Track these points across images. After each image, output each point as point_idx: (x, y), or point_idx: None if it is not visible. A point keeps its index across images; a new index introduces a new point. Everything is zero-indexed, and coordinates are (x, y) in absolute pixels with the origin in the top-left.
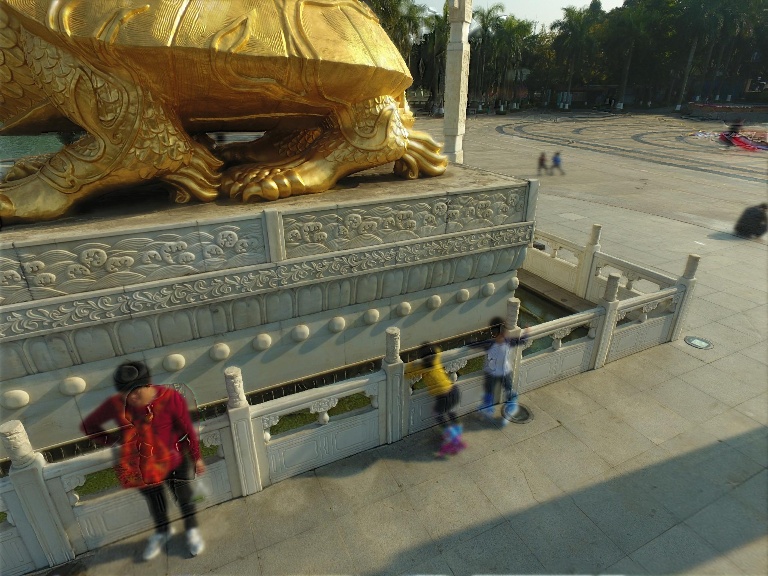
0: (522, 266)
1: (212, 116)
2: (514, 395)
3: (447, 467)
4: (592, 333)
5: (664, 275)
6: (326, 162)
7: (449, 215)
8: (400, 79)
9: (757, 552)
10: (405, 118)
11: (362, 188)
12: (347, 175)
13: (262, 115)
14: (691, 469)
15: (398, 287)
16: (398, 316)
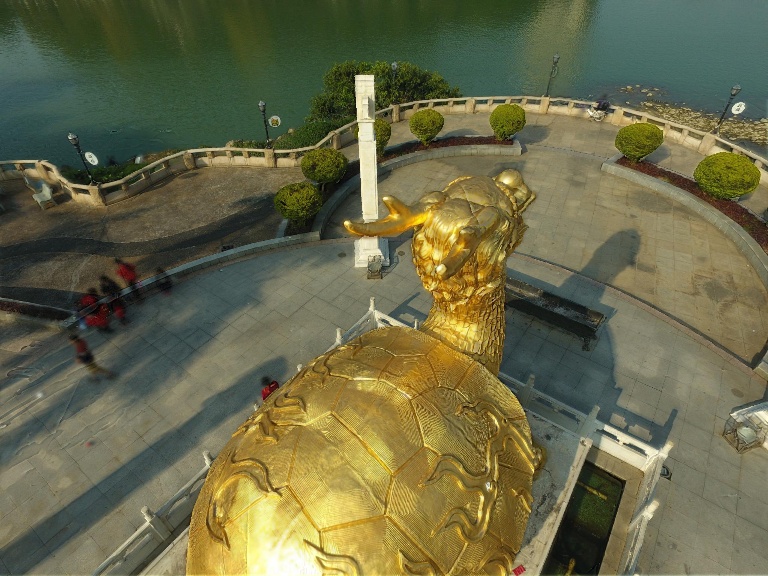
0: None
1: None
2: None
3: None
4: None
5: None
6: None
7: None
8: None
9: None
10: None
11: None
12: None
13: None
14: None
15: None
16: None
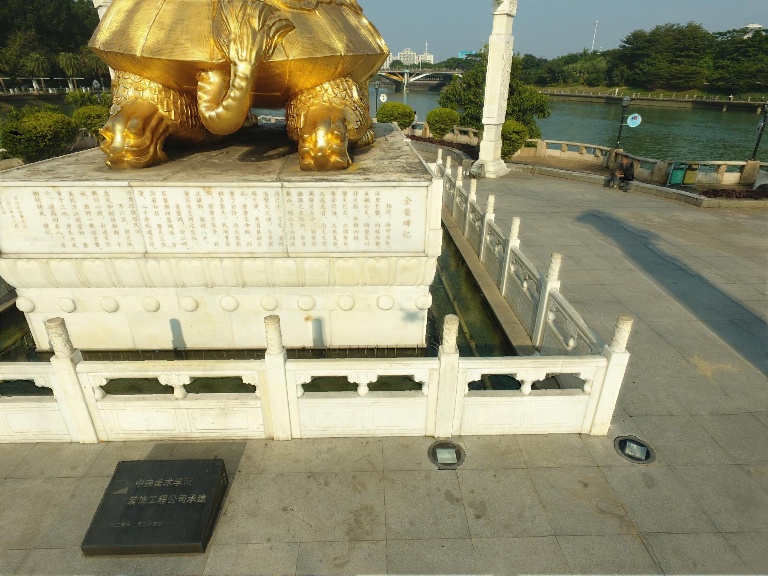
0: None
1: None
2: None
3: None
4: None
5: None
6: None
7: None
8: (101, 54)
9: None
10: None
11: None
12: None
13: None
14: None
15: None
16: None
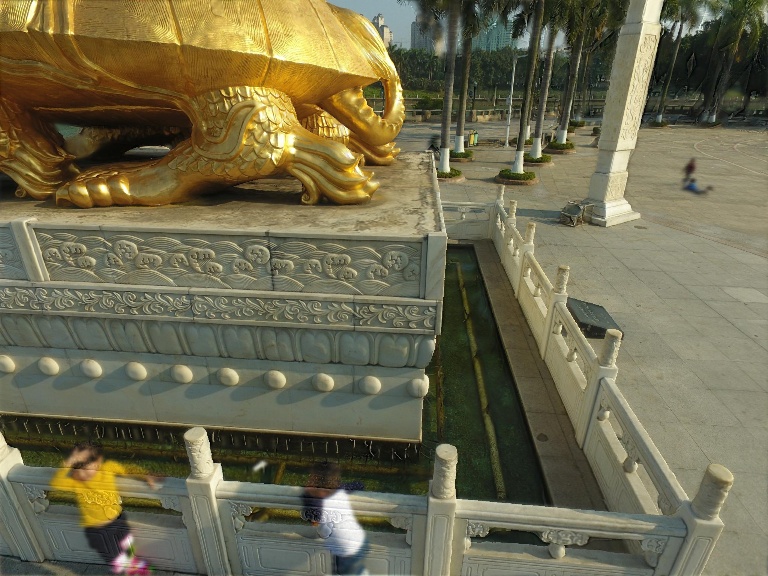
0: (544, 357)
1: (50, 106)
2: (241, 574)
3: None
4: (407, 536)
5: (671, 479)
6: (168, 169)
7: (275, 265)
8: (259, 63)
9: None
10: (372, 121)
11: (214, 207)
12: (210, 188)
13: (108, 107)
14: None
15: (210, 347)
16: (221, 383)
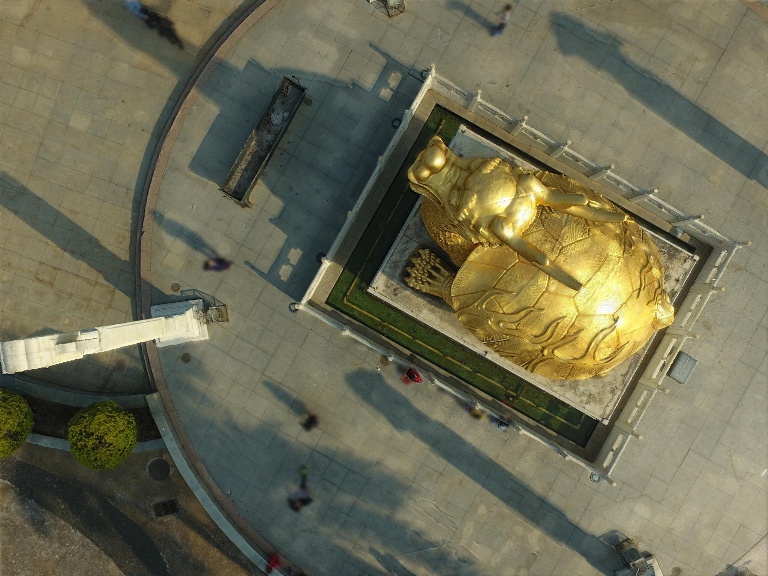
0: (639, 383)
1: None
2: None
3: (468, 417)
4: None
5: (612, 469)
6: None
7: None
8: None
9: (488, 492)
10: None
11: None
12: None
13: None
14: (509, 478)
15: None
16: None
